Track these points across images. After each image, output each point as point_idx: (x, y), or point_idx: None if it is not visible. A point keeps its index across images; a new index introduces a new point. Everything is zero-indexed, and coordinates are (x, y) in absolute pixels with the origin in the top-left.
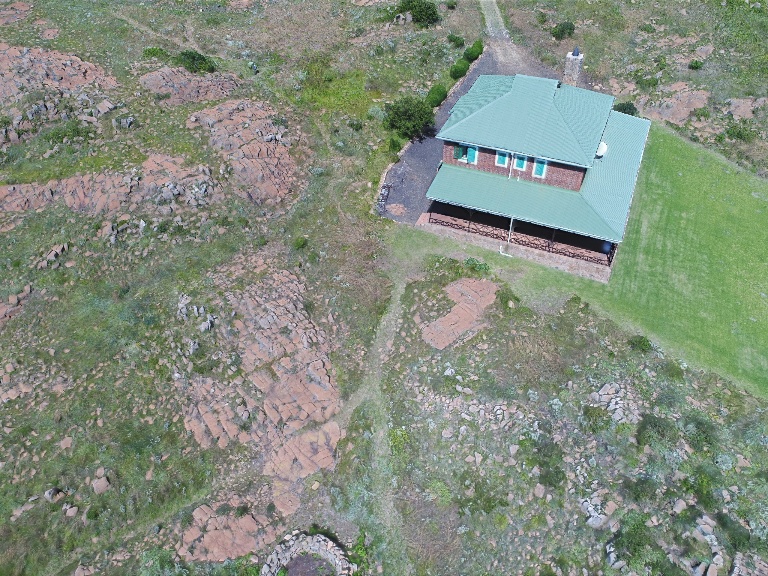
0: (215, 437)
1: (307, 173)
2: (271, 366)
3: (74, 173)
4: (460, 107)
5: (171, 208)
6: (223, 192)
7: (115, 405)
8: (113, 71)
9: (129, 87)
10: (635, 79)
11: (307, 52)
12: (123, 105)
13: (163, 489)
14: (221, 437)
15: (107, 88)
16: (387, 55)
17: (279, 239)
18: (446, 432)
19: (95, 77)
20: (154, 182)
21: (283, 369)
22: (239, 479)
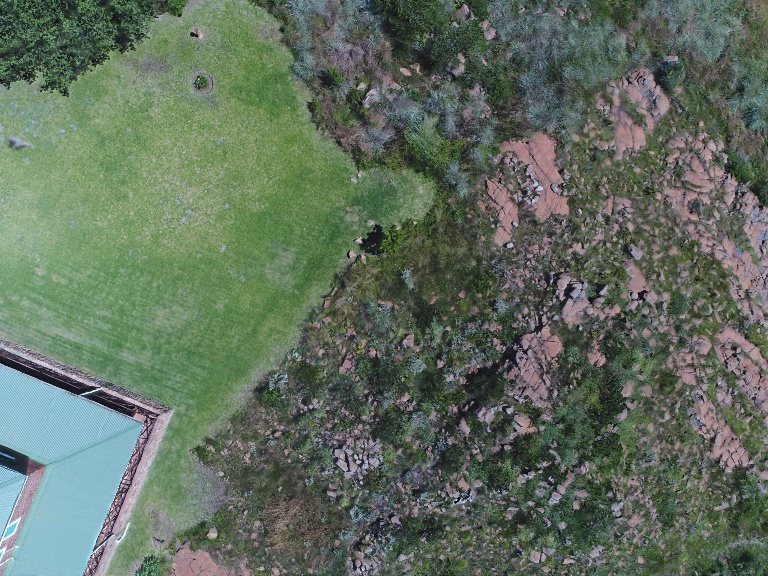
0: None
1: None
2: None
3: None
4: None
5: None
6: None
7: None
8: None
9: None
10: None
11: None
12: None
13: None
14: None
15: None
16: None
17: None
18: None
19: None
20: None
21: None
22: None
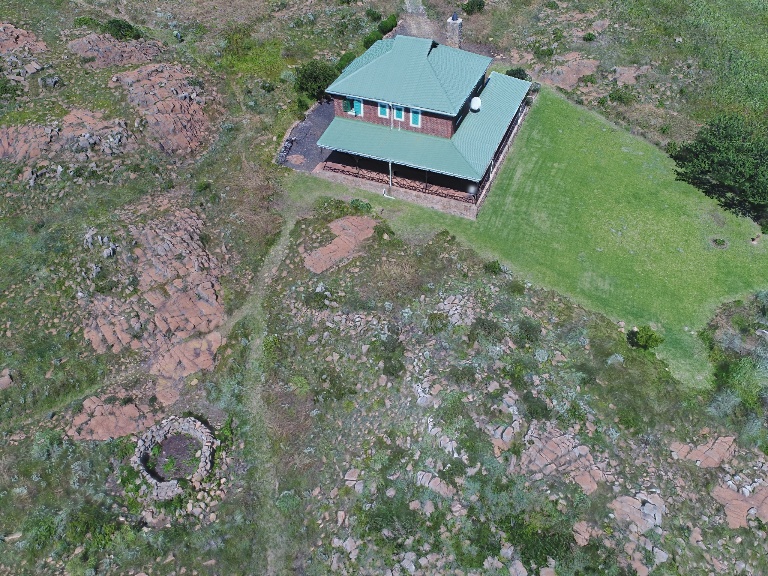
0: (110, 344)
1: (218, 128)
2: (165, 286)
3: (0, 125)
4: (352, 66)
5: (87, 155)
6: (137, 143)
7: (23, 319)
8: (44, 37)
9: (57, 51)
10: (534, 50)
11: (231, 23)
12: (50, 66)
13: (59, 384)
14: (115, 344)
15: (36, 52)
16: (306, 27)
17: (186, 184)
18: (312, 338)
19: (26, 42)
20: (72, 132)
21: (175, 288)
22: (128, 377)
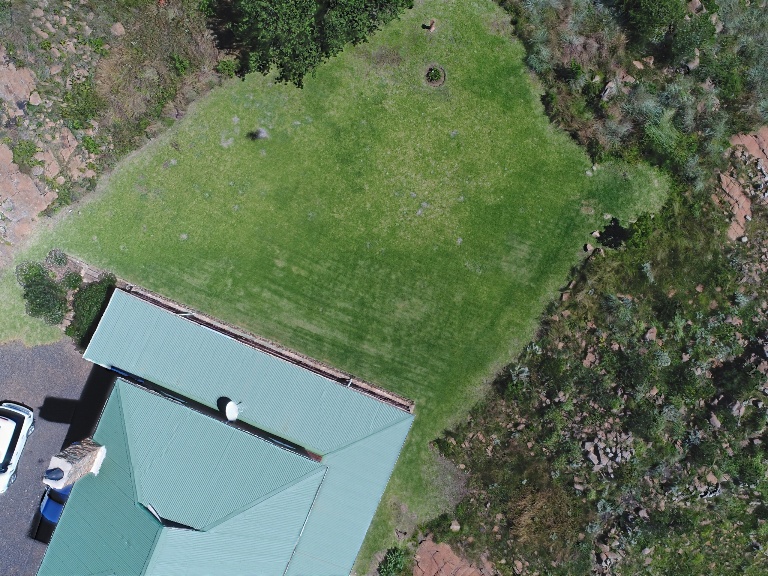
0: None
1: None
2: None
3: None
4: None
5: None
6: None
7: None
8: None
9: None
10: None
11: None
12: None
13: None
14: None
15: None
16: None
17: None
18: None
19: None
20: None
21: None
22: None
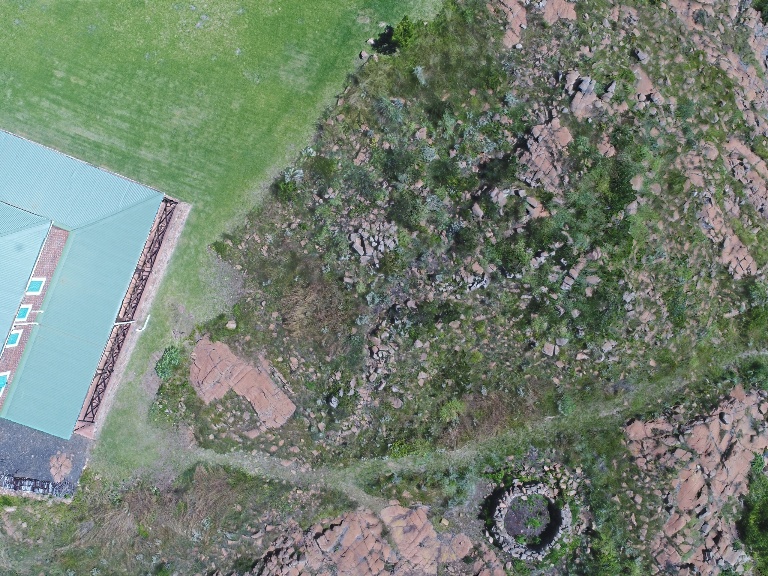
0: None
1: None
2: None
3: None
4: None
5: None
6: None
7: None
8: None
9: None
10: None
11: None
12: None
13: None
14: None
15: None
16: None
17: None
18: (396, 405)
19: None
20: None
21: None
22: None
